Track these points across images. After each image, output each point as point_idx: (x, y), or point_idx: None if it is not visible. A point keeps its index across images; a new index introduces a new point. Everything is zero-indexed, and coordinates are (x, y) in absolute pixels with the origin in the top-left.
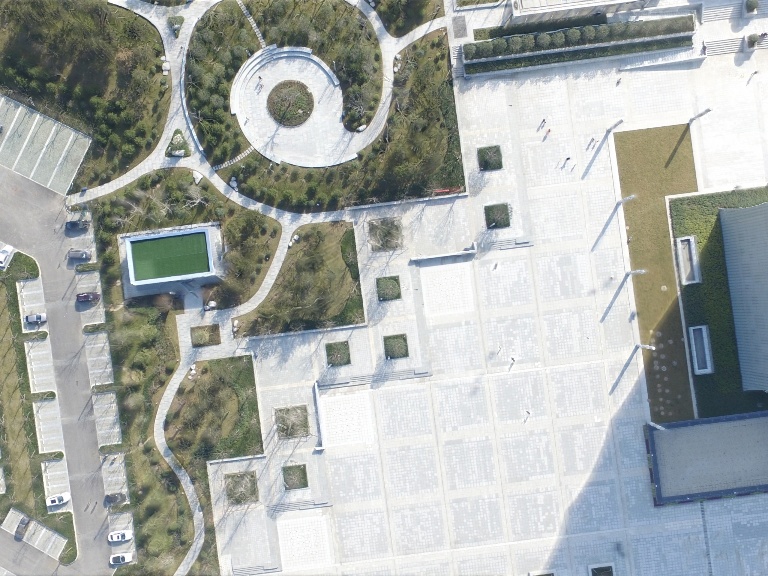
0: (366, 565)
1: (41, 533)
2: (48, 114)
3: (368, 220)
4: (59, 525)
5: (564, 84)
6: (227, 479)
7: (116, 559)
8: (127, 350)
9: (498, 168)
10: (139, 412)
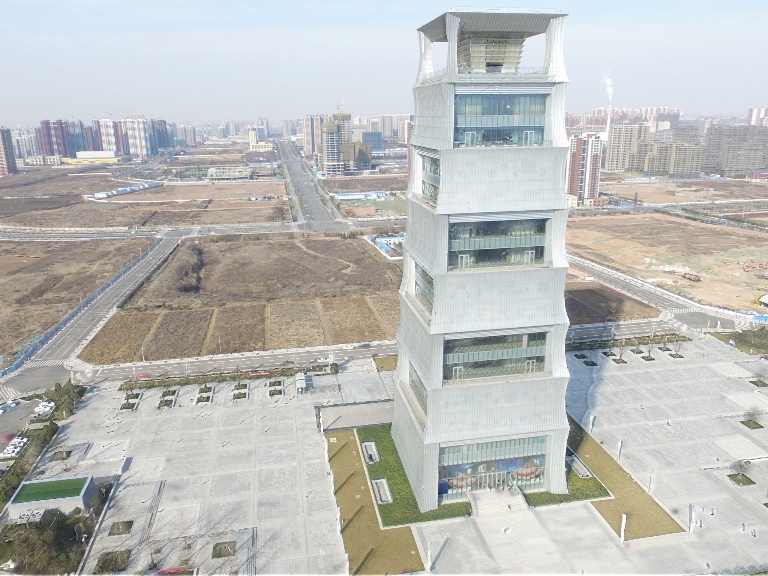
0: None
1: None
2: None
3: None
4: None
5: (760, 562)
6: None
7: None
8: None
9: None
10: None
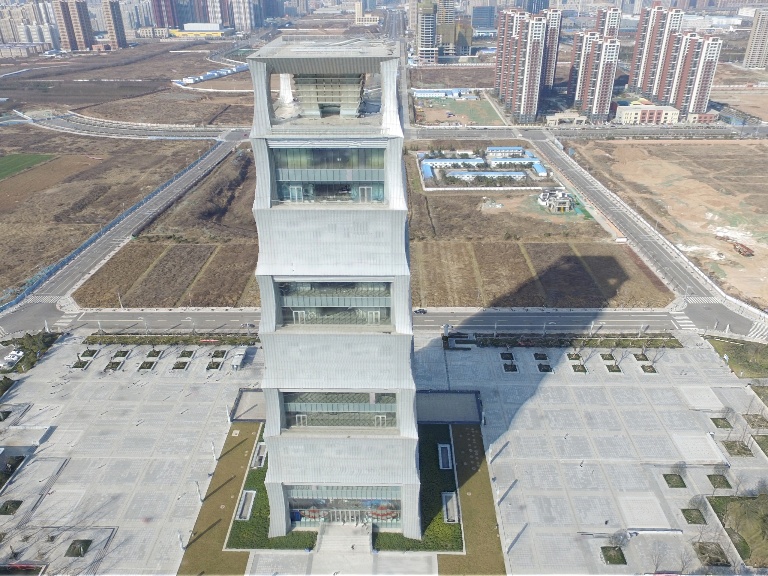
0: (657, 385)
1: None
2: None
3: (732, 567)
4: None
5: None
6: None
7: None
8: None
9: None
10: None
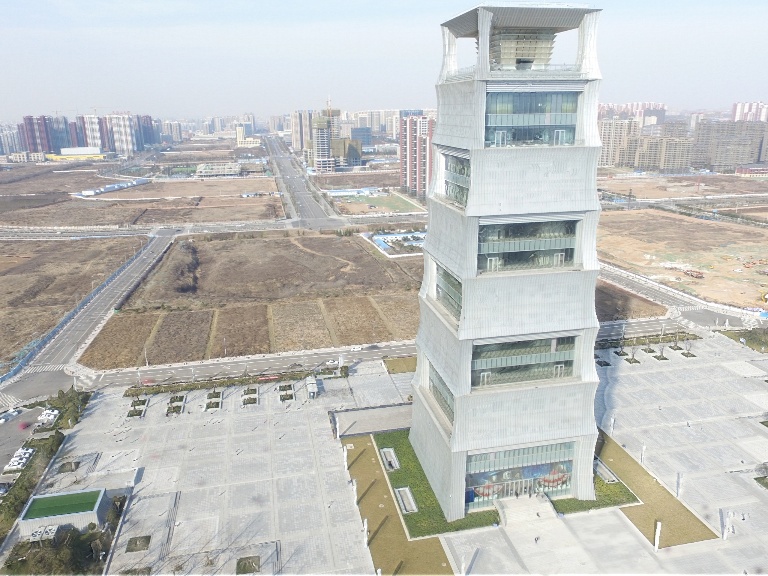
0: None
1: None
2: None
3: None
4: None
5: None
6: None
7: None
8: None
9: None
10: None
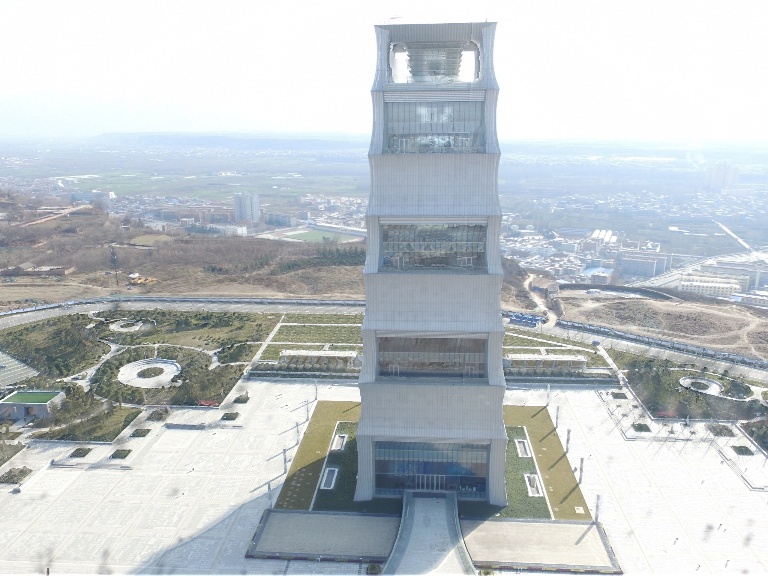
0: None
1: None
2: (32, 366)
3: None
4: None
5: (300, 386)
6: None
7: None
8: None
9: (244, 403)
10: None
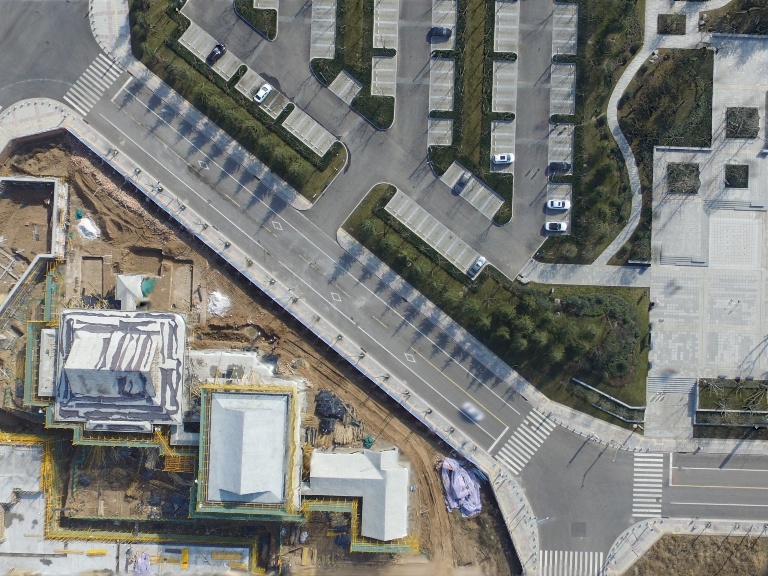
0: None
1: (479, 191)
2: None
3: None
4: (501, 184)
5: None
6: (672, 166)
7: (553, 225)
8: (596, 24)
9: None
10: (598, 86)
